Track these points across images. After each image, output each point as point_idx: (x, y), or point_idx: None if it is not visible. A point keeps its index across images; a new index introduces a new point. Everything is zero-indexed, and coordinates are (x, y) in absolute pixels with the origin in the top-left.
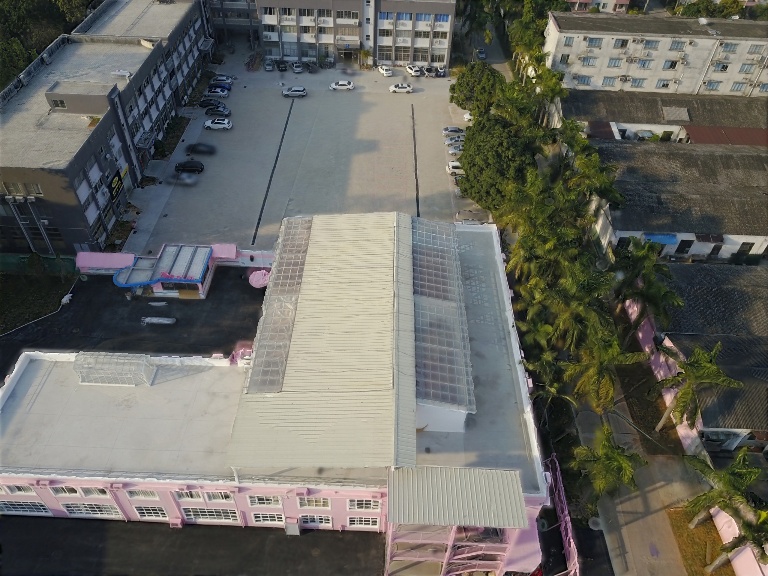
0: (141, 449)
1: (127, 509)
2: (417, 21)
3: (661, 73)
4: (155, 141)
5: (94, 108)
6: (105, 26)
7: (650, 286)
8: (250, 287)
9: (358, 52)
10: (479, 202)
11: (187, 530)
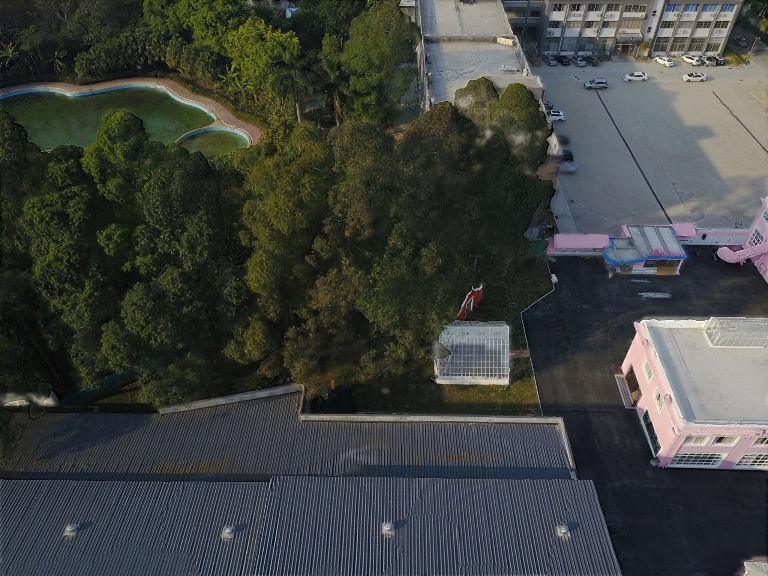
0: None
1: None
2: (702, 12)
3: None
4: None
5: None
6: (436, 27)
7: None
8: (713, 263)
9: (636, 44)
10: None
11: None
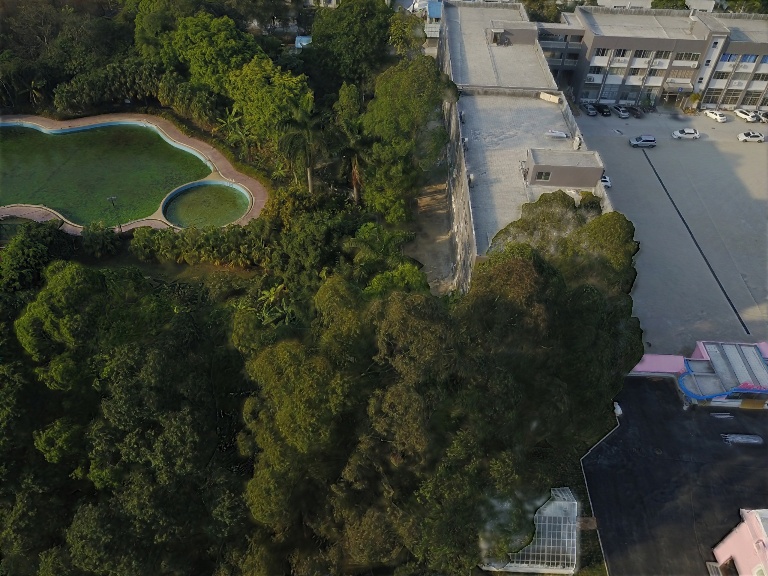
0: None
1: None
2: (761, 63)
3: None
4: None
5: (578, 180)
6: (467, 73)
7: None
8: None
9: (684, 95)
10: None
11: None
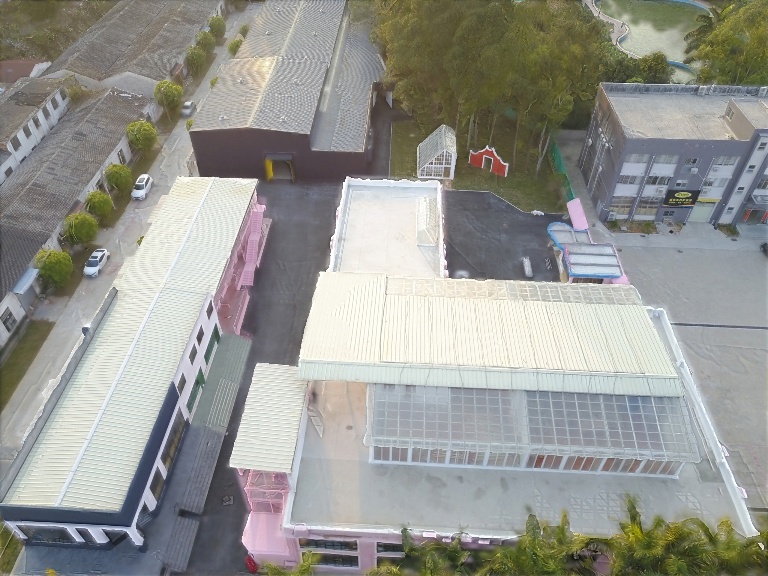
0: (361, 250)
1: None
2: None
3: None
4: None
5: None
6: None
7: None
8: None
9: None
10: None
11: None
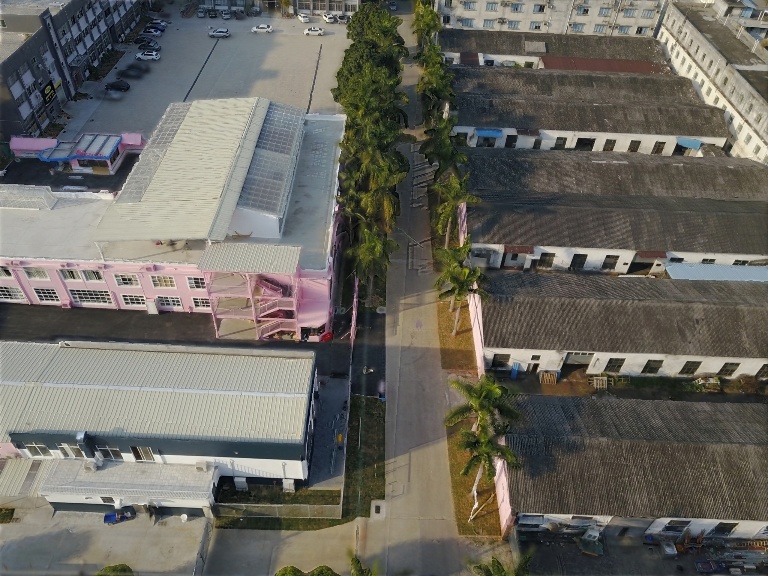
0: (38, 245)
1: (29, 291)
2: None
3: (532, 16)
4: (90, 66)
5: (29, 27)
6: None
7: (444, 147)
8: None
9: (280, 2)
10: (347, 106)
11: (75, 310)
